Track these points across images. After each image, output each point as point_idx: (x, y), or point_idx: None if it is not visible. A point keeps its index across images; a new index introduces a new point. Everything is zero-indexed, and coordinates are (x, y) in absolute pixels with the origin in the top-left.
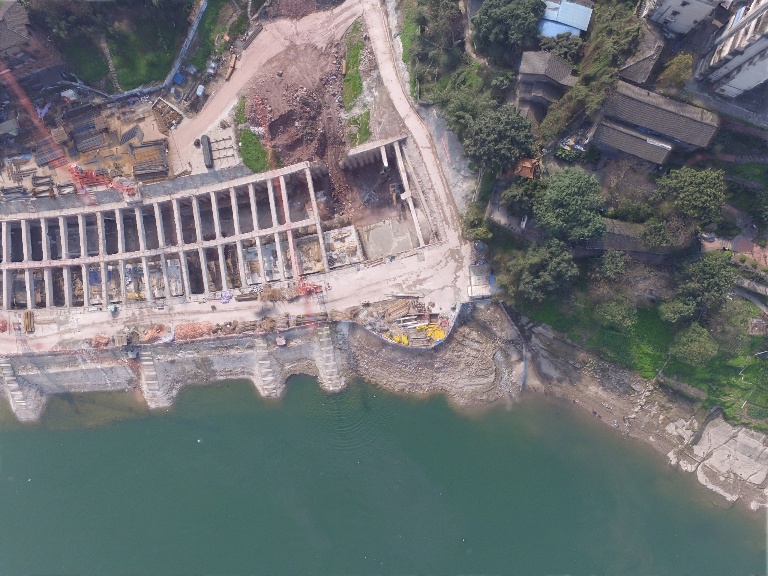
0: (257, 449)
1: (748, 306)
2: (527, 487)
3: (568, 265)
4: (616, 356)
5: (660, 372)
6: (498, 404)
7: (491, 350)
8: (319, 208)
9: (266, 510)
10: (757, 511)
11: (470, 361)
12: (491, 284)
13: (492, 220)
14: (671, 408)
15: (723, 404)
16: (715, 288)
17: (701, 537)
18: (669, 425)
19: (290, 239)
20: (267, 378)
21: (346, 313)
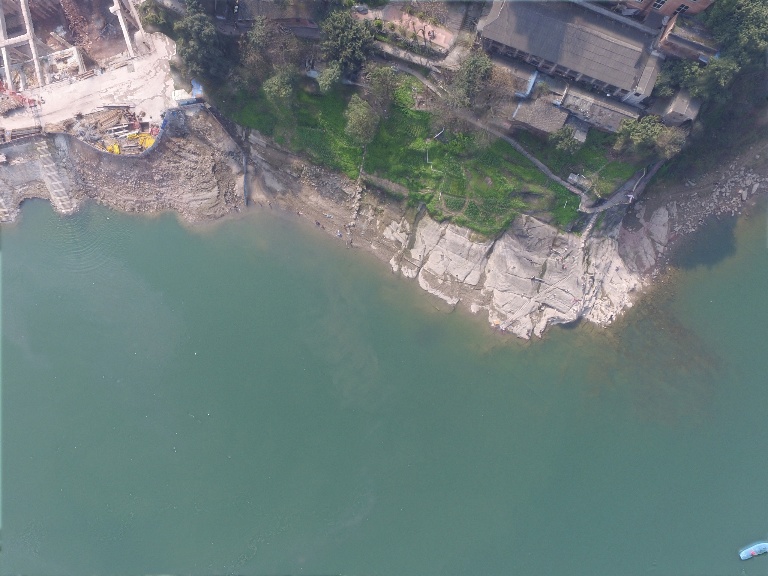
0: None
1: (409, 79)
2: (257, 300)
3: (203, 25)
4: (320, 156)
5: (361, 169)
6: (226, 220)
7: (209, 162)
8: (60, 43)
9: (7, 335)
10: (477, 313)
11: (189, 173)
12: (193, 88)
13: (157, 3)
14: (383, 210)
15: (423, 198)
16: (348, 44)
17: (426, 342)
18: (386, 230)
19: (4, 56)
20: None
21: (59, 125)
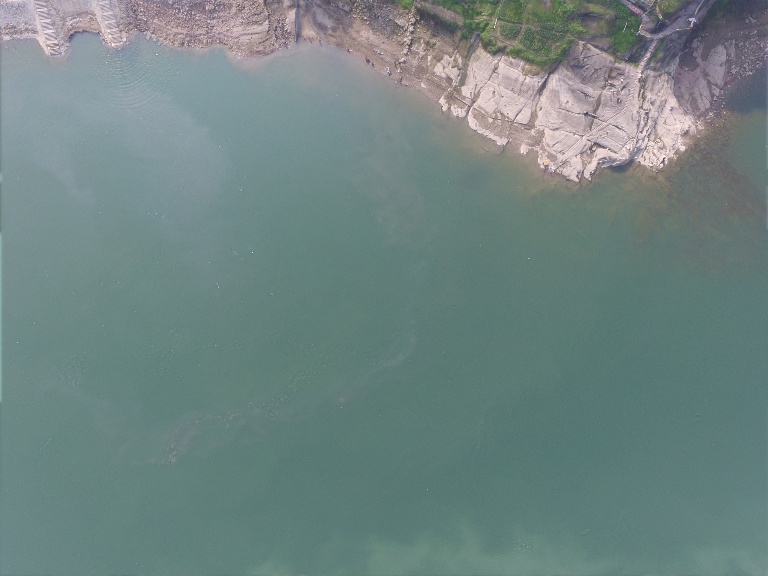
0: (45, 111)
1: None
2: (304, 138)
3: None
4: None
5: None
6: (275, 56)
7: None
8: None
9: (53, 170)
10: (527, 155)
11: (241, 4)
12: None
13: None
14: (435, 44)
15: (478, 26)
16: None
17: (473, 183)
18: (437, 66)
19: None
20: (48, 31)
21: None
